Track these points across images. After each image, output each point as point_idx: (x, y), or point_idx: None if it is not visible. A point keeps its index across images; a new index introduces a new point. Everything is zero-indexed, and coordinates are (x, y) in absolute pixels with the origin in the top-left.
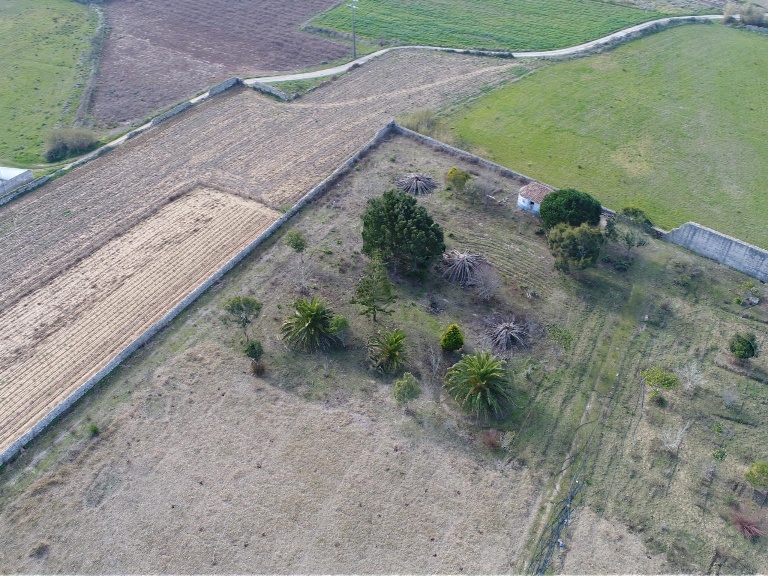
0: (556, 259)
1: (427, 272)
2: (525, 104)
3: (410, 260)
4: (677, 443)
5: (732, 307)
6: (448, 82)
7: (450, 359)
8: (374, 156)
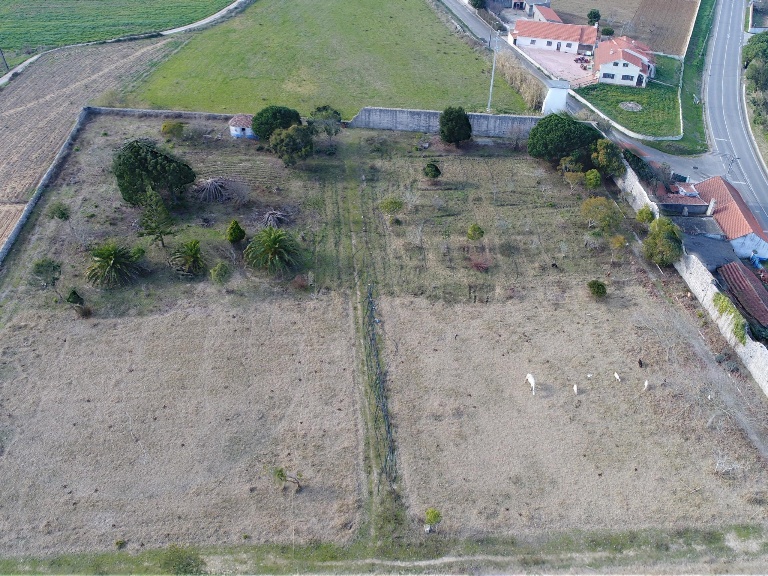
0: (284, 157)
1: (186, 202)
2: (194, 67)
3: (169, 195)
4: (419, 240)
5: (414, 154)
6: (115, 67)
7: (241, 247)
8: (86, 136)
